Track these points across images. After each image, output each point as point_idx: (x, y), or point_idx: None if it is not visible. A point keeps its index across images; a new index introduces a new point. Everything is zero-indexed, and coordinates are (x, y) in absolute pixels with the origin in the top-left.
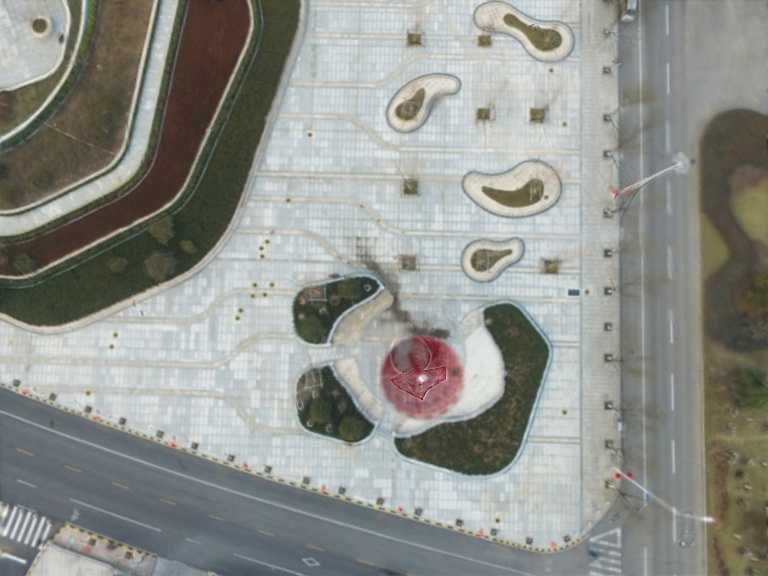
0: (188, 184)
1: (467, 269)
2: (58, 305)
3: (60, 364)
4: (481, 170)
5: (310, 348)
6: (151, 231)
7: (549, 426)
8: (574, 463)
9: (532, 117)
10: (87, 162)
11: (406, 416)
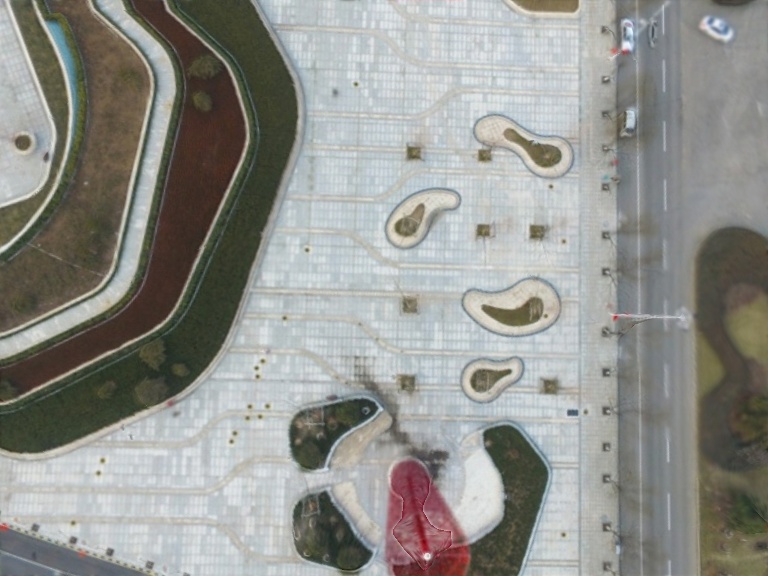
0: (180, 304)
1: (467, 389)
2: (41, 431)
3: (43, 492)
4: (481, 287)
5: (307, 473)
6: (141, 355)
7: (548, 549)
8: None
9: (532, 234)
10: (73, 284)
11: None
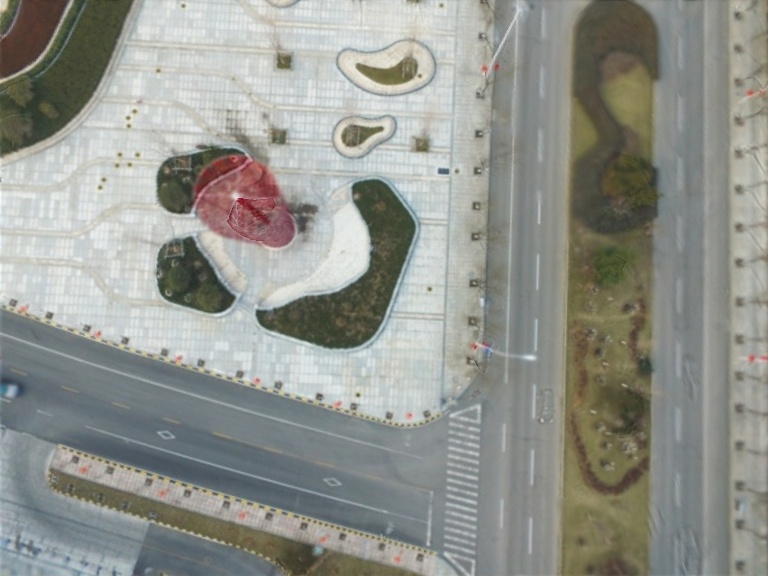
0: (51, 47)
1: (338, 145)
2: None
3: None
4: (356, 47)
5: (173, 218)
6: (9, 92)
7: (414, 302)
8: (437, 339)
9: None
10: None
11: (270, 290)
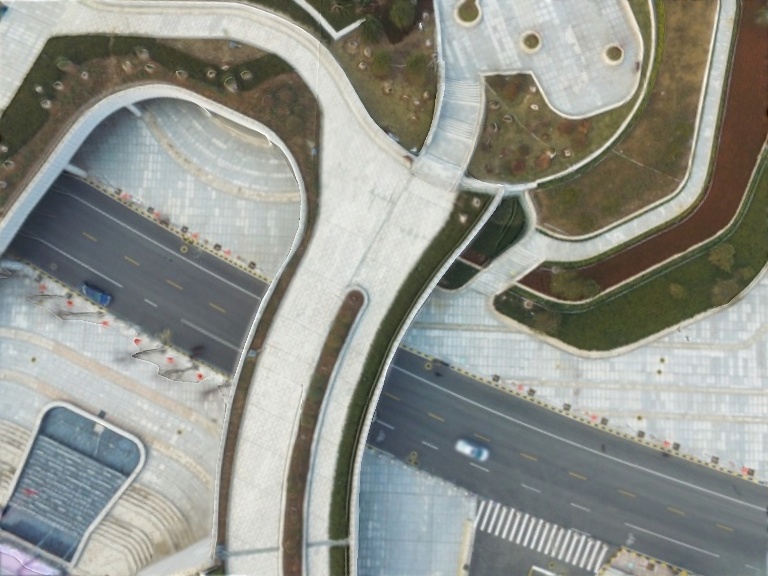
0: (739, 211)
1: None
2: (611, 330)
3: (609, 389)
4: None
5: None
6: (711, 258)
7: None
8: None
9: None
10: (652, 189)
11: None
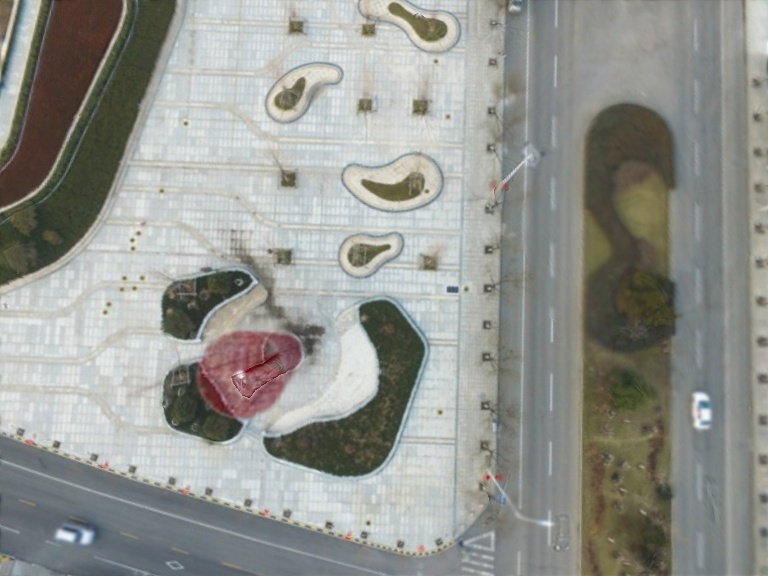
0: (54, 172)
1: (344, 264)
2: None
3: None
4: (361, 162)
5: (179, 344)
6: (13, 221)
7: (424, 426)
8: (448, 464)
9: (415, 109)
10: None
11: (278, 415)
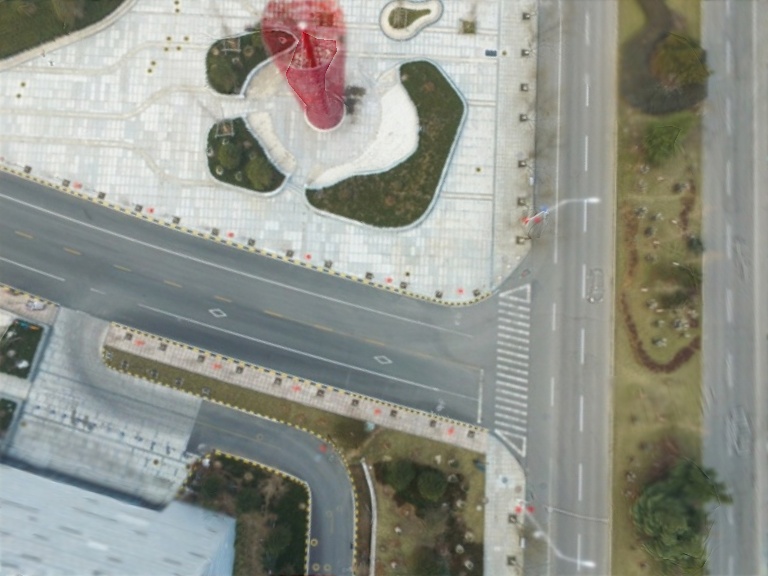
0: None
1: (385, 28)
2: None
3: None
4: None
5: (223, 99)
6: None
7: (462, 182)
8: (486, 219)
9: None
10: None
11: (319, 171)
